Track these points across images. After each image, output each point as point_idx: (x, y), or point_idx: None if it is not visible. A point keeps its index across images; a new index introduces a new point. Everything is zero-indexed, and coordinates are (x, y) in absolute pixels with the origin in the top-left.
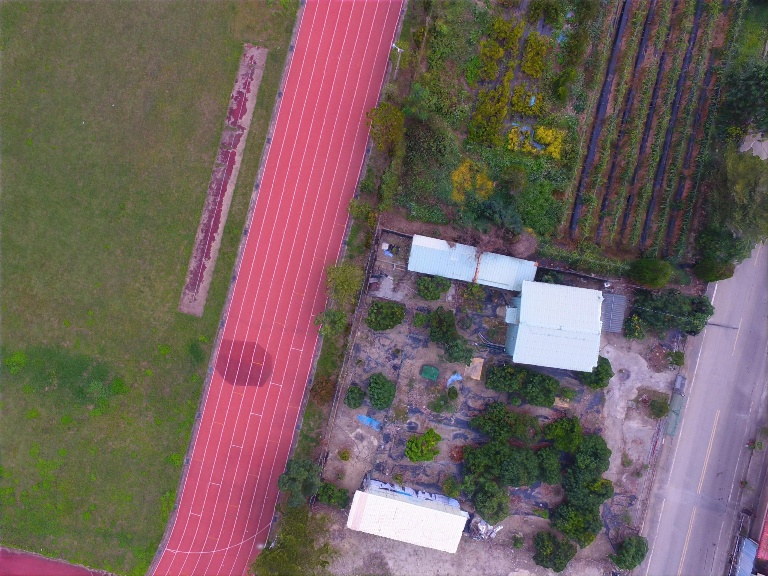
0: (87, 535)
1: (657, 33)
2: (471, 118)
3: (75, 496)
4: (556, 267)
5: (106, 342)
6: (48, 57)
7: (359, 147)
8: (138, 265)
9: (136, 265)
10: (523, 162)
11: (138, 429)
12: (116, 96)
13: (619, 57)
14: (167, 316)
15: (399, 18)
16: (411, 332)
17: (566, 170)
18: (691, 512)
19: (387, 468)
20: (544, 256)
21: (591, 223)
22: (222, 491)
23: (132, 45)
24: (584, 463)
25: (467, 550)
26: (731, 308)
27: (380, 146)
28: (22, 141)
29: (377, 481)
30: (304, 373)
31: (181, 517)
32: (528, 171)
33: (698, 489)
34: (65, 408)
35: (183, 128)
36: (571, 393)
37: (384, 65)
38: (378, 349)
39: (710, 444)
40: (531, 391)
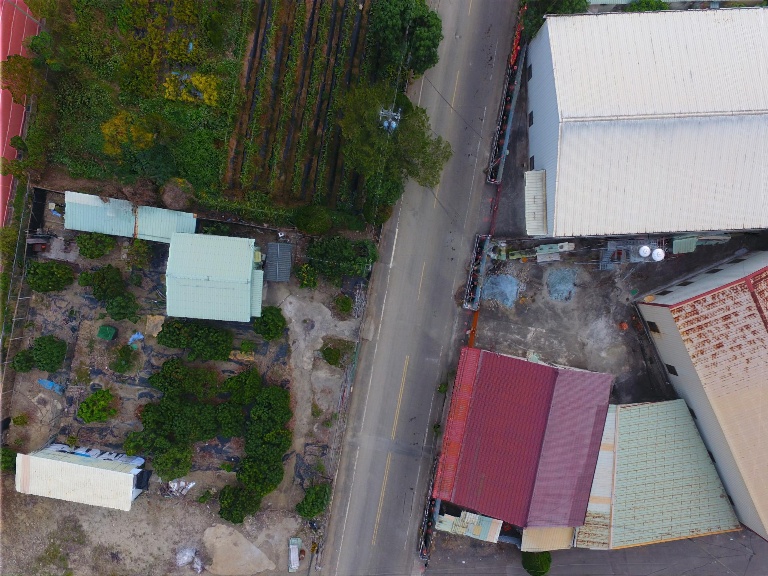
0: None
1: None
2: None
3: None
4: (227, 219)
5: None
6: None
7: (18, 104)
8: None
9: None
10: (181, 112)
11: None
12: None
13: None
14: None
15: None
16: (86, 293)
17: (225, 118)
18: (386, 458)
19: (73, 431)
20: (211, 208)
21: (253, 171)
22: None
23: None
24: (256, 414)
25: (162, 508)
26: (413, 252)
27: (14, 100)
28: None
29: (62, 444)
30: None
31: None
32: (188, 121)
33: (392, 435)
34: None
35: None
36: (246, 345)
37: None
38: (55, 312)
39: (401, 390)
40: (195, 345)
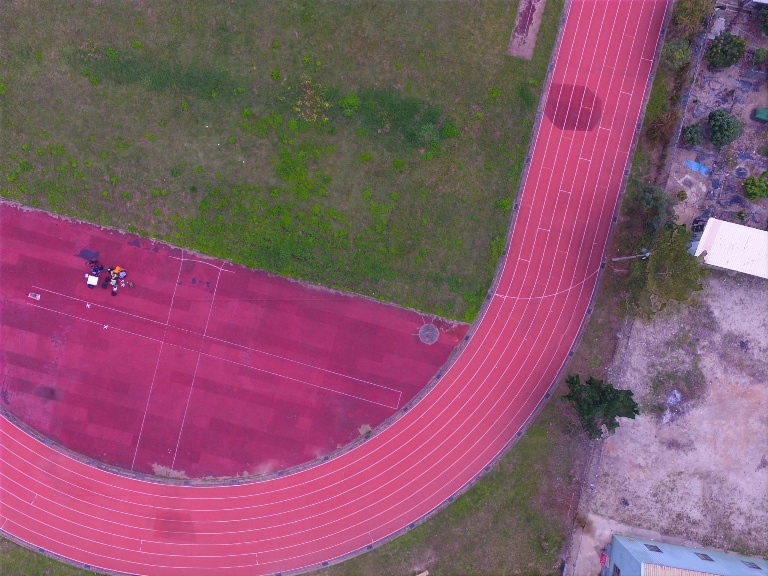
0: (419, 279)
1: None
2: None
3: (407, 239)
4: None
5: (437, 85)
6: None
7: None
8: (468, 7)
9: (466, 7)
10: None
11: (468, 173)
12: None
13: None
14: (497, 59)
15: None
16: (743, 75)
17: None
18: None
19: (716, 214)
20: None
21: None
22: (551, 237)
23: None
24: None
25: None
26: None
27: None
28: None
29: None
30: (633, 117)
31: (510, 262)
32: None
33: None
34: (397, 151)
35: None
36: None
37: None
38: (708, 93)
39: None
40: None
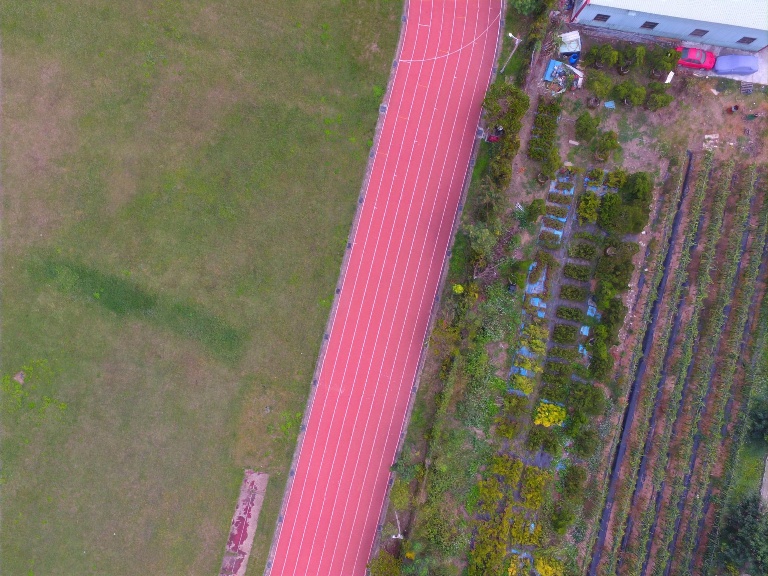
0: None
1: (655, 476)
2: (471, 546)
3: None
4: None
5: None
6: (50, 489)
7: (359, 570)
8: None
9: None
10: None
11: None
12: (117, 525)
13: (617, 486)
14: None
15: (399, 442)
16: None
17: None
18: None
19: None
20: None
21: None
22: None
23: (134, 474)
24: None
25: None
26: None
27: None
28: (24, 573)
29: None
30: None
31: None
32: None
33: None
34: None
35: (184, 555)
36: None
37: (384, 488)
38: None
39: None
40: None
